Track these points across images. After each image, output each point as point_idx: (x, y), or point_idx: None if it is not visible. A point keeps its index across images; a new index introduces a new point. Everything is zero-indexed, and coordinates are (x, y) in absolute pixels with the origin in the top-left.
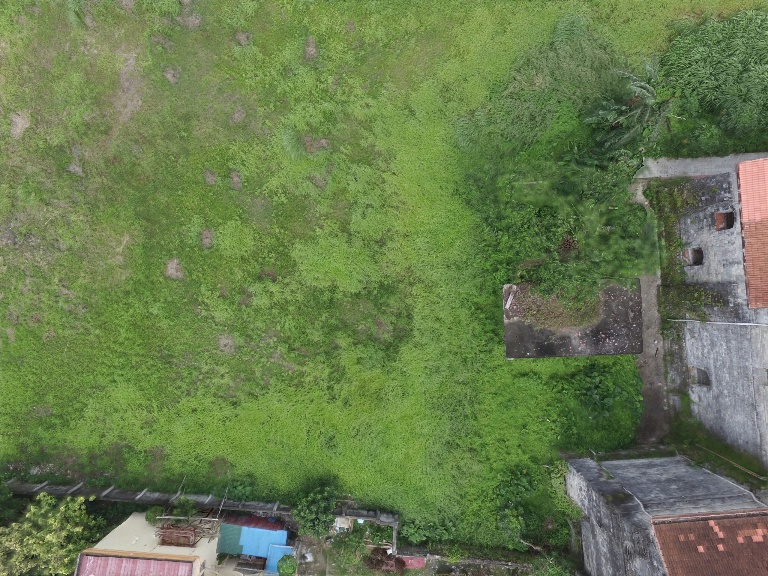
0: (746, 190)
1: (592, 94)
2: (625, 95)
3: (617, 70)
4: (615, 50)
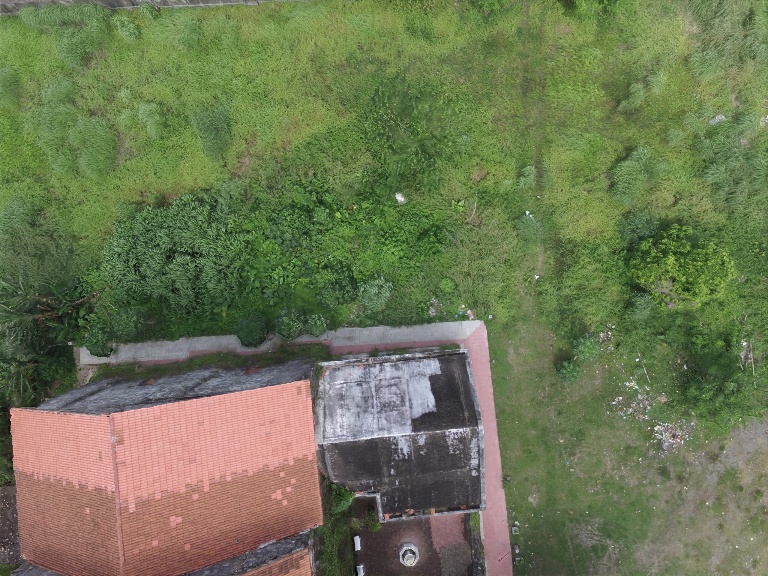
0: (15, 437)
1: (34, 282)
2: (70, 281)
3: (61, 256)
4: (62, 235)
